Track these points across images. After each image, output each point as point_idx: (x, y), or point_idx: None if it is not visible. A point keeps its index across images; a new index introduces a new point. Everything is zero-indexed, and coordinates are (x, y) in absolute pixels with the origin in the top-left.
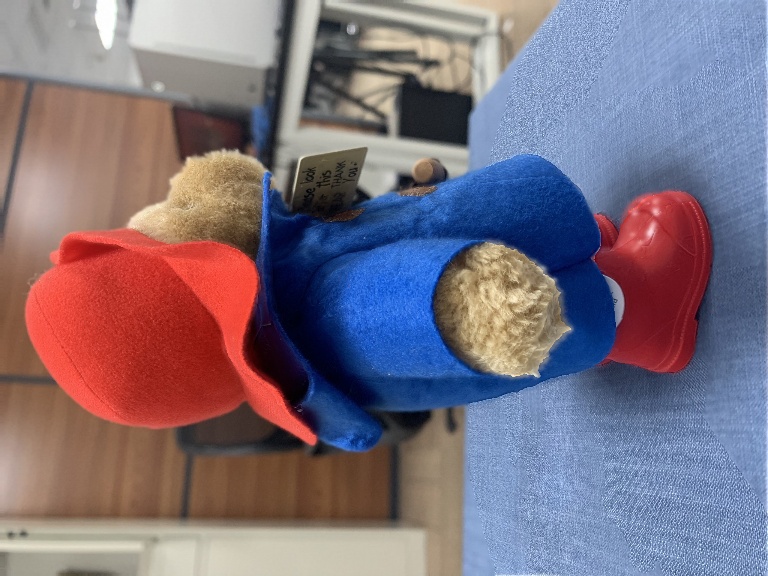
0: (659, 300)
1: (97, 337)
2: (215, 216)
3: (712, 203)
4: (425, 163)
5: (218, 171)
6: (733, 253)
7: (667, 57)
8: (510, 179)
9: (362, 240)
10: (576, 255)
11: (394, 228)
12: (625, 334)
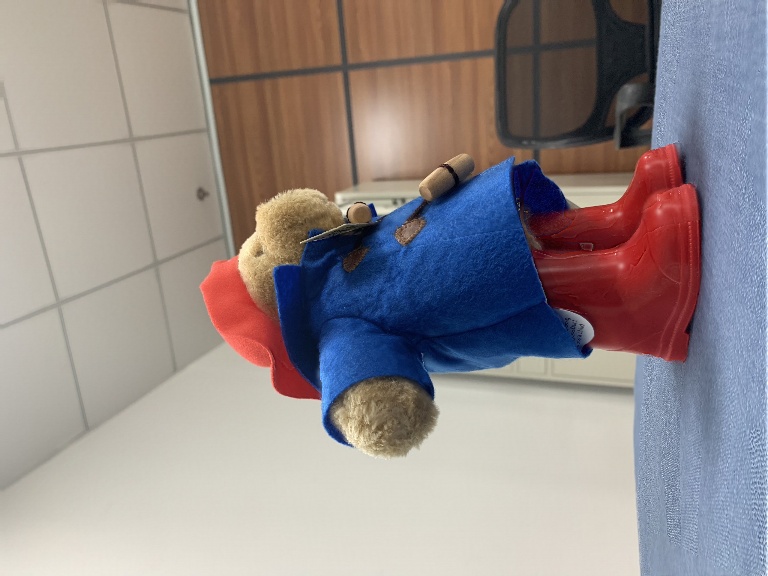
0: (641, 317)
1: (235, 340)
2: (271, 269)
3: (703, 234)
4: (424, 188)
5: (272, 223)
6: (701, 301)
7: (717, 1)
8: (467, 236)
9: (343, 309)
10: (517, 310)
11: (363, 299)
12: (605, 341)
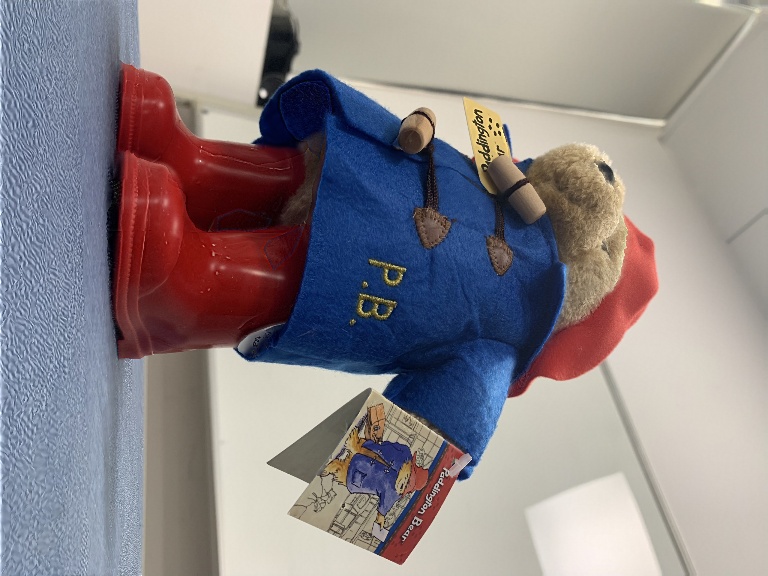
0: None
1: None
2: None
3: None
4: None
5: None
6: None
7: None
8: None
9: None
10: None
11: None
12: None
